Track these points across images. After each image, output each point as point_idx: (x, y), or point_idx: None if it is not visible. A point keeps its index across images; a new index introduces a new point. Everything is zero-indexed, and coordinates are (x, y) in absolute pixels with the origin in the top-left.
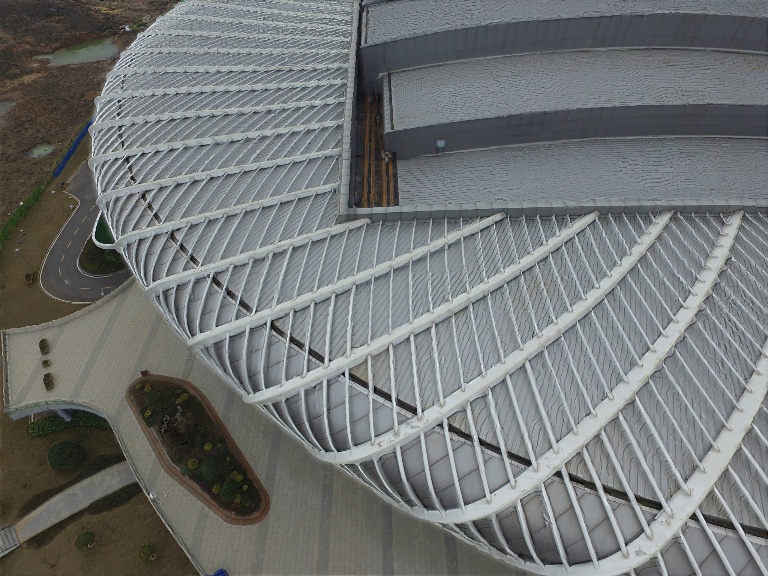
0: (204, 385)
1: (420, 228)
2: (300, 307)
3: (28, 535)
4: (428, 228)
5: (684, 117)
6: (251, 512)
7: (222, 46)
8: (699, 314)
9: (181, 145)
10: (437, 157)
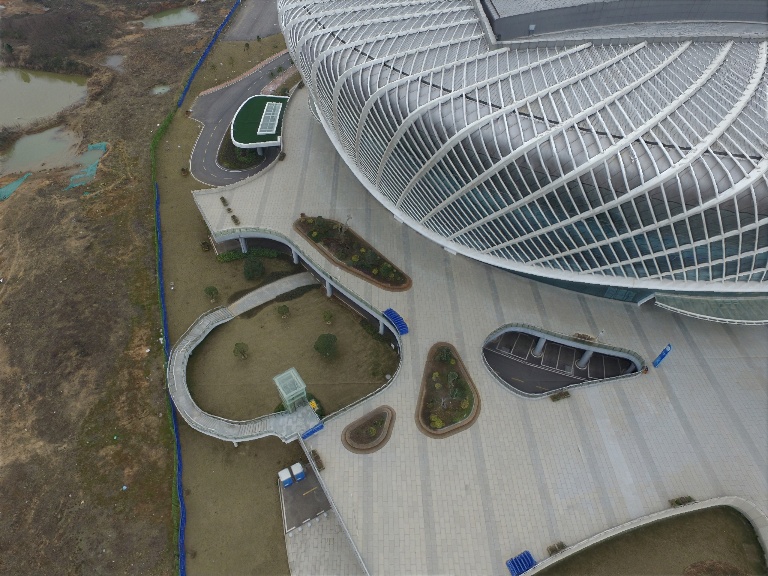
0: (347, 222)
1: (541, 52)
2: (480, 87)
3: (239, 312)
4: (546, 51)
5: (695, 6)
6: (401, 284)
7: None
8: (708, 81)
9: (370, 22)
10: (528, 39)
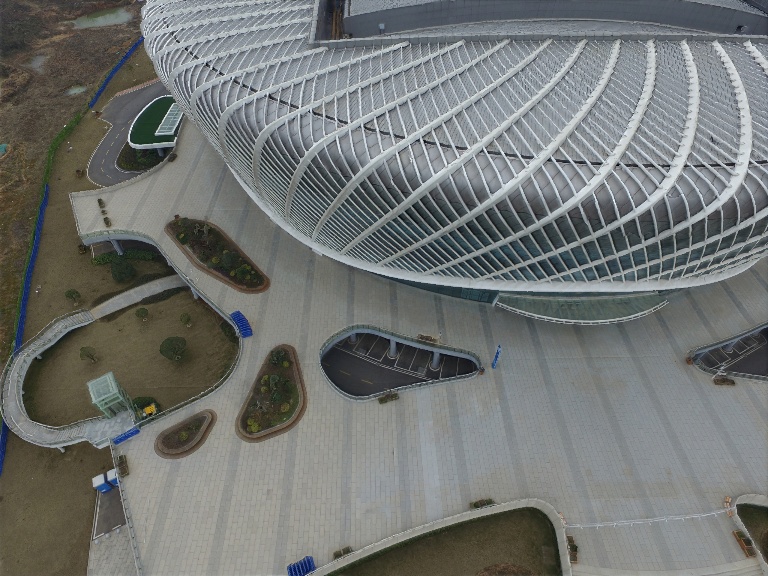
0: (221, 224)
1: (358, 51)
2: (285, 87)
3: (100, 315)
4: (362, 51)
5: (542, 4)
6: (257, 285)
7: None
8: (509, 80)
9: (208, 22)
10: None
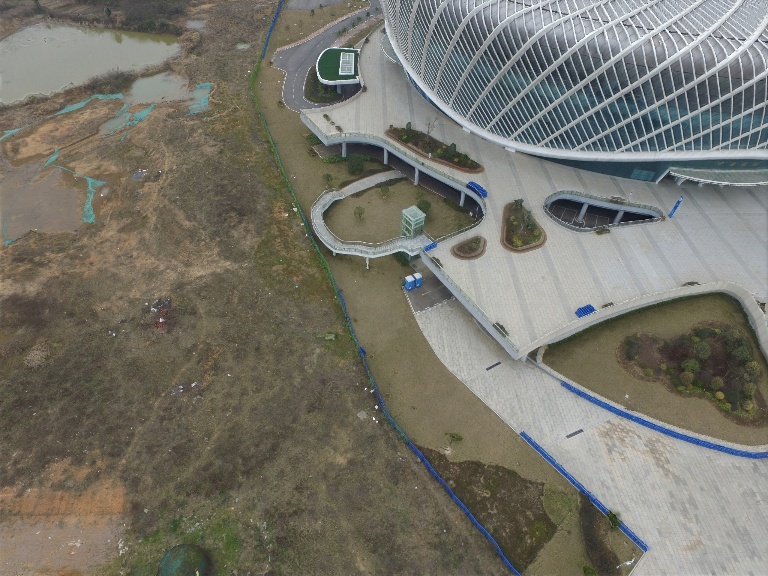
0: (426, 132)
1: None
2: (552, 2)
3: (349, 194)
4: None
5: None
6: (477, 168)
7: None
8: None
9: None
10: None
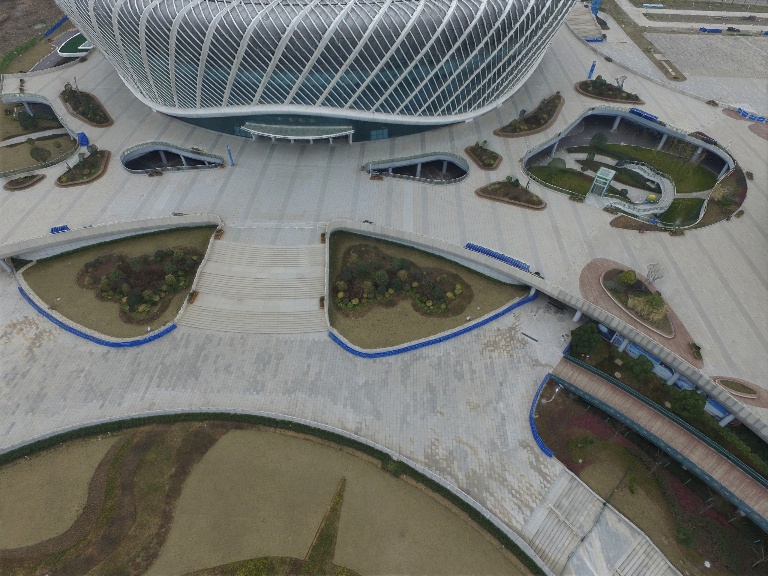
0: (98, 95)
1: None
2: None
3: None
4: None
5: None
6: (103, 123)
7: None
8: None
9: None
10: None
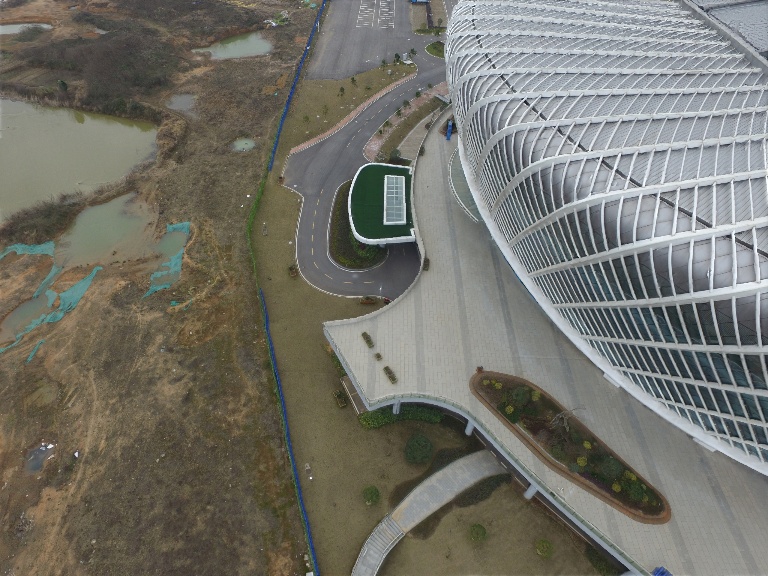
0: (542, 383)
1: None
2: None
3: (409, 525)
4: None
5: None
6: (659, 511)
7: (594, 48)
8: None
9: (666, 148)
10: None
